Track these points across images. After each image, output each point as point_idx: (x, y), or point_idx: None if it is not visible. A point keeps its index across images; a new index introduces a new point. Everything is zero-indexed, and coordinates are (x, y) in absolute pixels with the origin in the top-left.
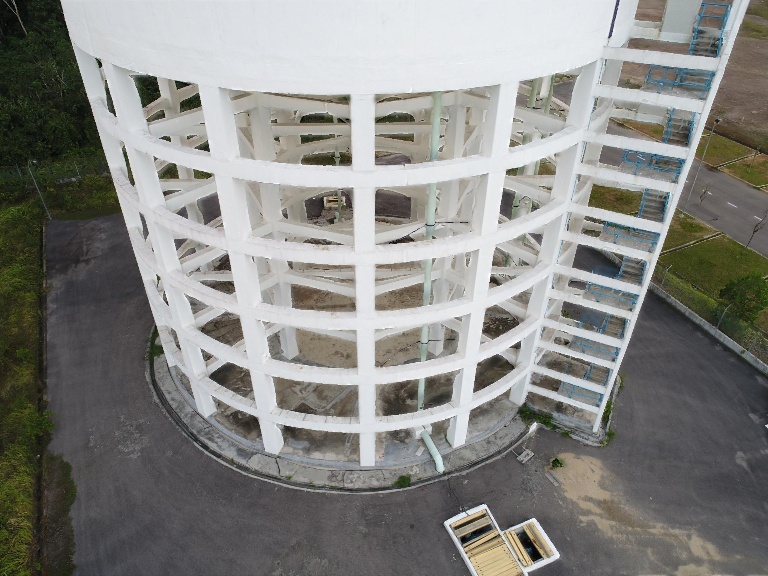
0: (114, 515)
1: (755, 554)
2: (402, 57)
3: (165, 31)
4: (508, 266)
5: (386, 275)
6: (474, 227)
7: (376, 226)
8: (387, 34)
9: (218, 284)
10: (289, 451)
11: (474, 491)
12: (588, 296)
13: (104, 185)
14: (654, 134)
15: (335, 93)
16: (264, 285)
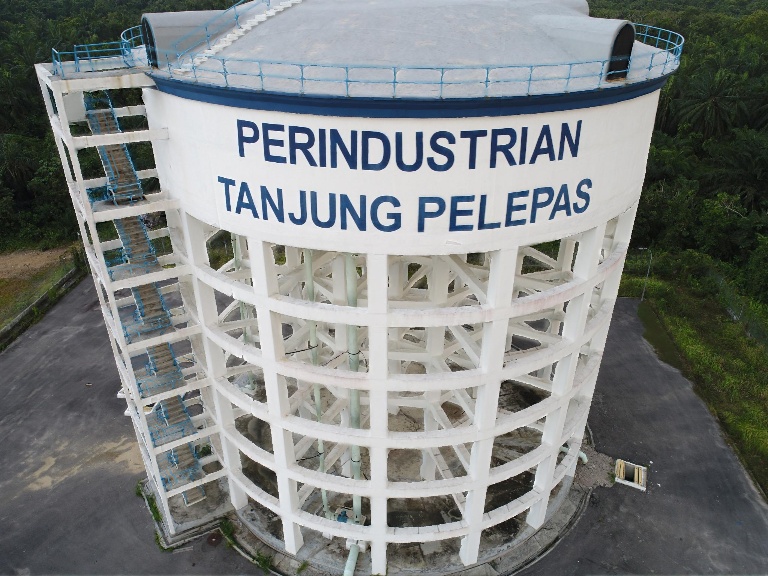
0: None
1: (4, 507)
2: None
3: None
4: (351, 519)
5: None
6: None
7: None
8: None
9: None
10: None
11: None
12: None
13: (726, 334)
14: None
15: None
16: None
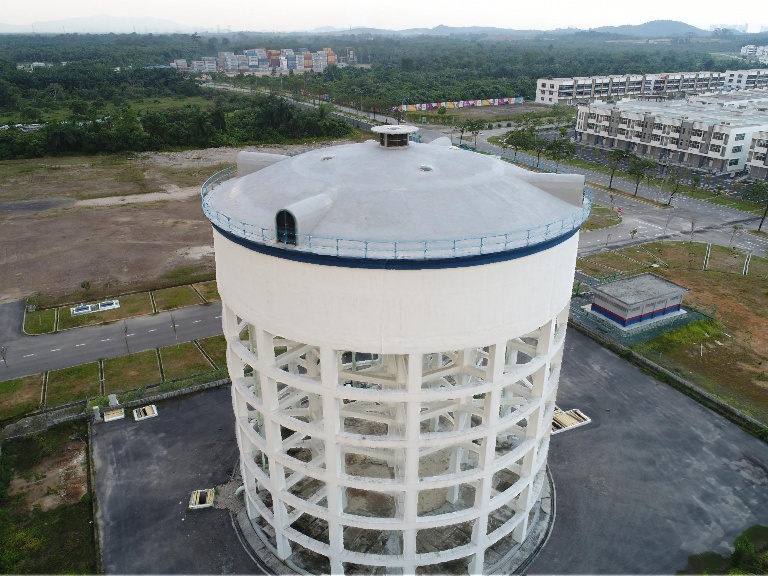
0: None
1: (526, 360)
2: None
3: None
4: (358, 386)
5: None
6: None
7: None
8: None
9: (362, 567)
10: None
11: None
12: None
13: None
14: (136, 313)
15: None
16: None
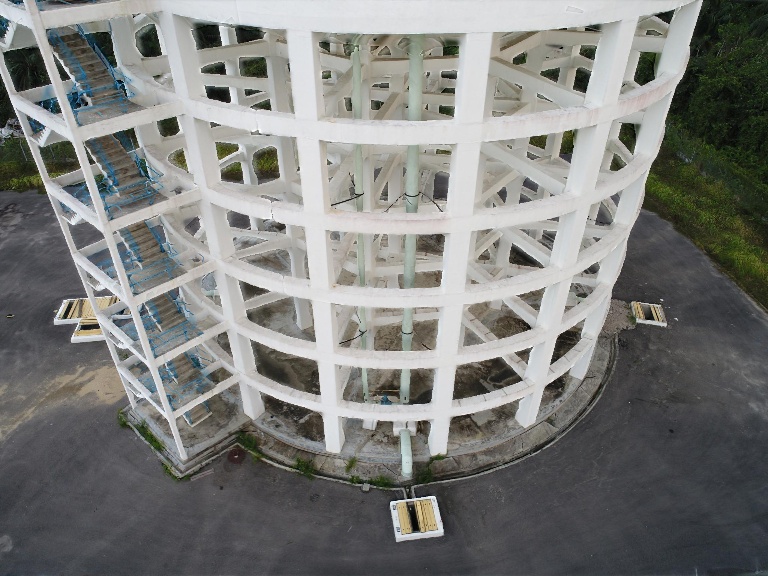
0: None
1: None
2: None
3: None
4: (397, 403)
5: None
6: None
7: None
8: None
9: None
10: None
11: None
12: None
13: (683, 177)
14: None
15: None
16: (331, 159)
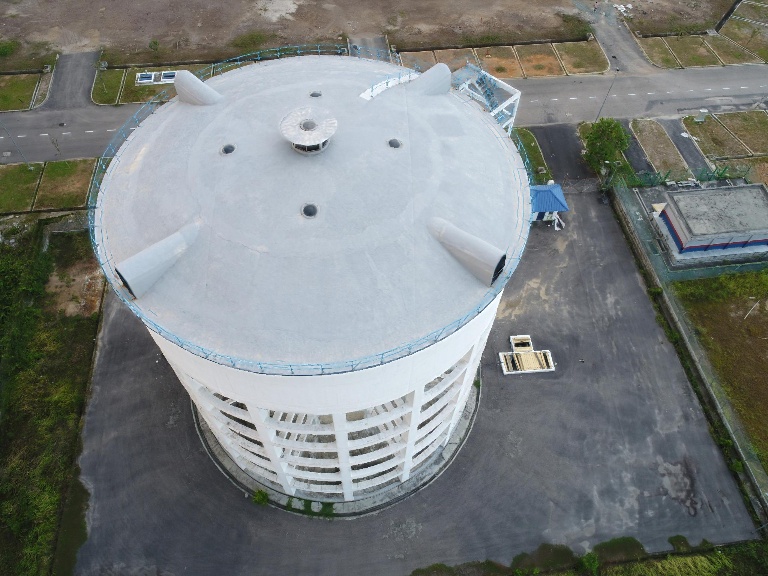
0: (460, 539)
1: (540, 268)
2: None
3: None
4: None
5: None
6: None
7: None
8: None
9: None
10: None
11: (490, 355)
12: None
13: None
14: None
15: None
16: None
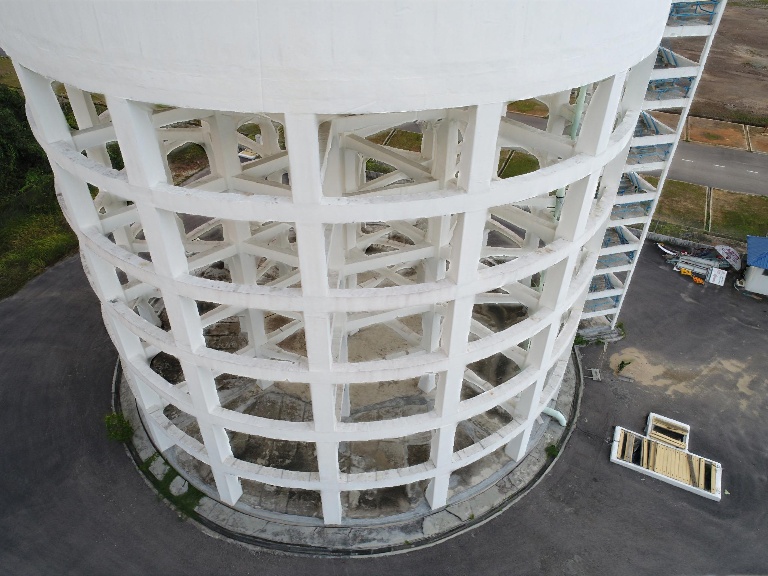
0: None
1: (753, 351)
2: (649, 25)
3: (449, 46)
4: None
5: (373, 286)
6: (606, 183)
7: (362, 238)
8: (648, 3)
9: None
10: (451, 494)
11: (598, 422)
12: (613, 217)
13: None
14: None
15: (606, 76)
16: None
